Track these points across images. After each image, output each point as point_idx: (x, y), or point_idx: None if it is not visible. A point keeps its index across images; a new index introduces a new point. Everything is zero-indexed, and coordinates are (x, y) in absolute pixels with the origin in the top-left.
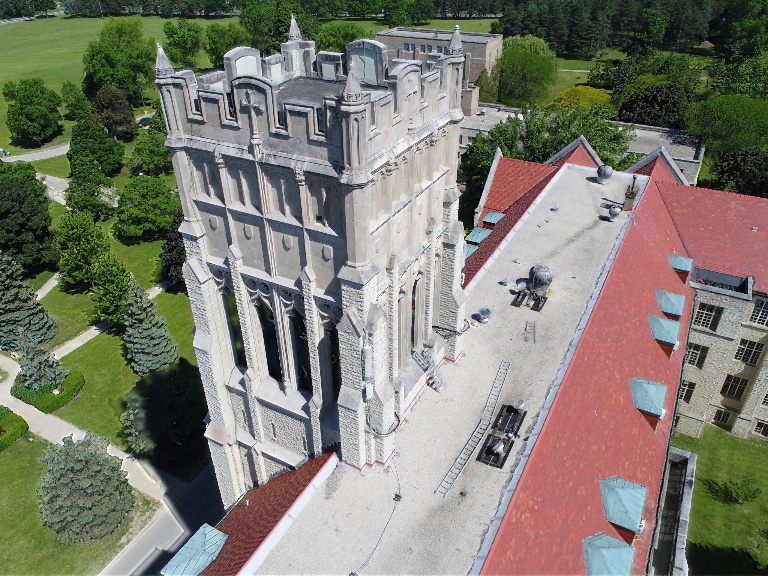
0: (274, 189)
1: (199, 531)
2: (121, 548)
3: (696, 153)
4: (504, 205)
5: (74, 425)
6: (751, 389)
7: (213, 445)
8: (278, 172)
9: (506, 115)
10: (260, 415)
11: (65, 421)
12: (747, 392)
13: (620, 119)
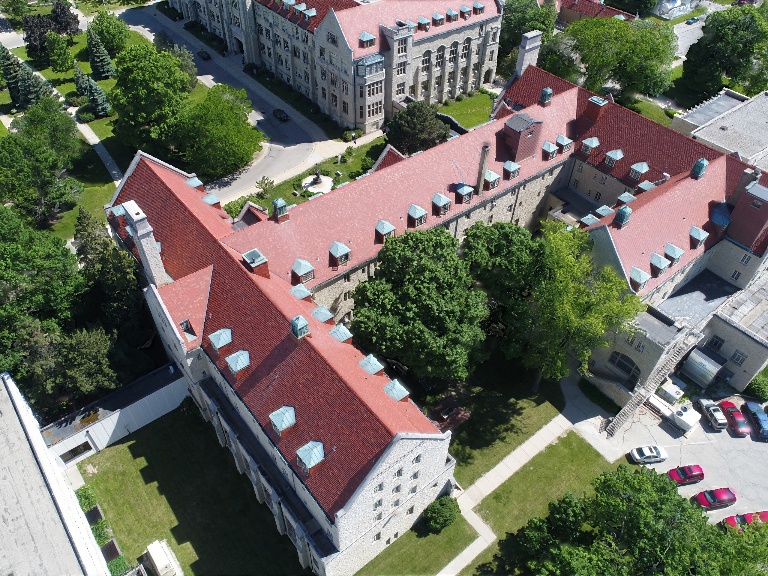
0: None
1: None
2: None
3: None
4: None
5: None
6: None
7: None
8: None
9: None
10: None
11: None
12: None
13: None
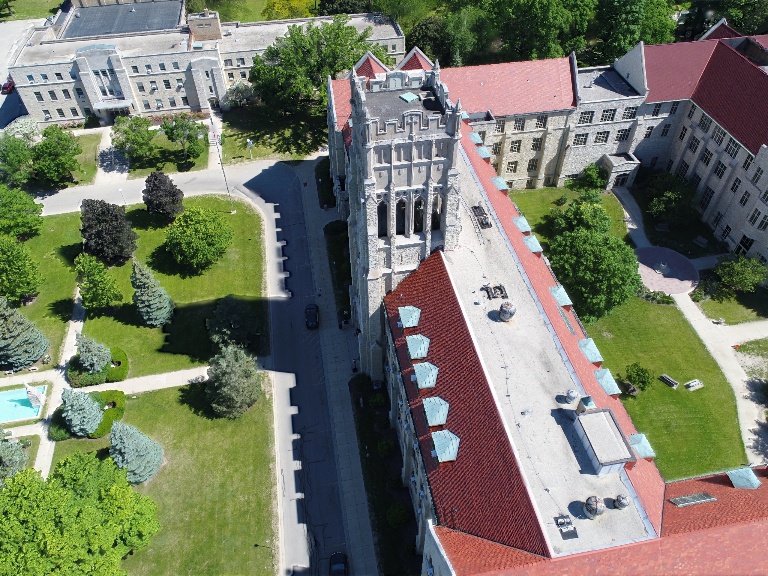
0: (417, 150)
1: (400, 310)
2: (271, 400)
3: (395, 29)
4: (348, 112)
5: (153, 374)
6: (501, 167)
7: (371, 282)
8: (421, 143)
9: (247, 30)
10: (395, 255)
11: (143, 376)
12: (499, 169)
13: (327, 11)
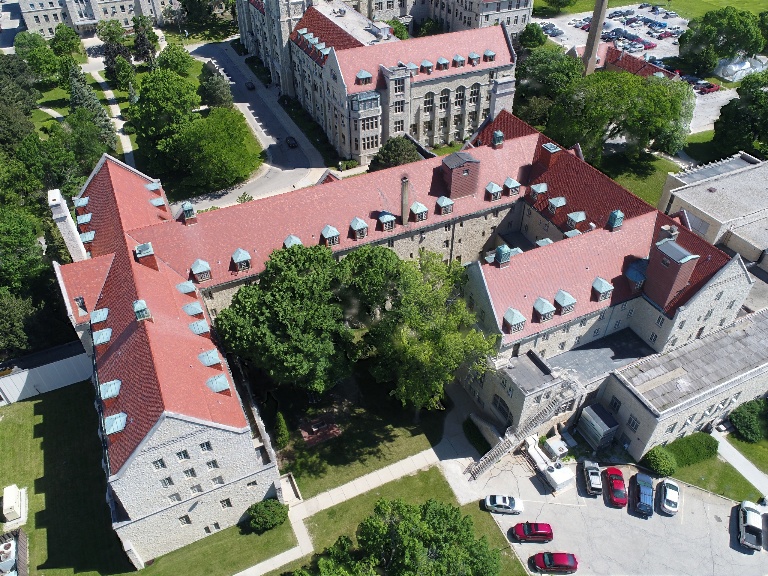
0: None
1: None
2: (239, 110)
3: None
4: None
5: None
6: None
7: (282, 23)
8: None
9: None
10: None
11: None
12: None
13: None
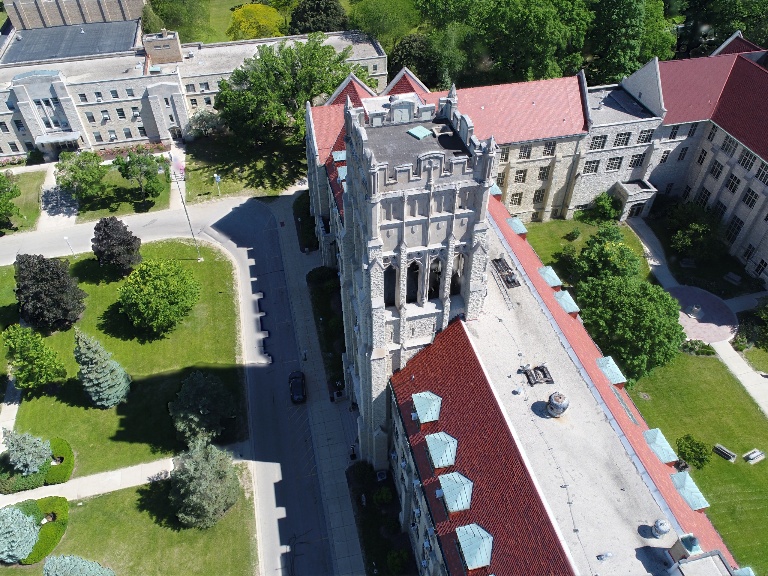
0: (435, 202)
1: (414, 399)
2: (252, 500)
3: (375, 48)
4: (331, 143)
5: (105, 471)
6: (505, 200)
7: (376, 362)
8: (442, 193)
9: (210, 51)
10: (405, 328)
11: (92, 475)
12: None
13: (299, 30)
